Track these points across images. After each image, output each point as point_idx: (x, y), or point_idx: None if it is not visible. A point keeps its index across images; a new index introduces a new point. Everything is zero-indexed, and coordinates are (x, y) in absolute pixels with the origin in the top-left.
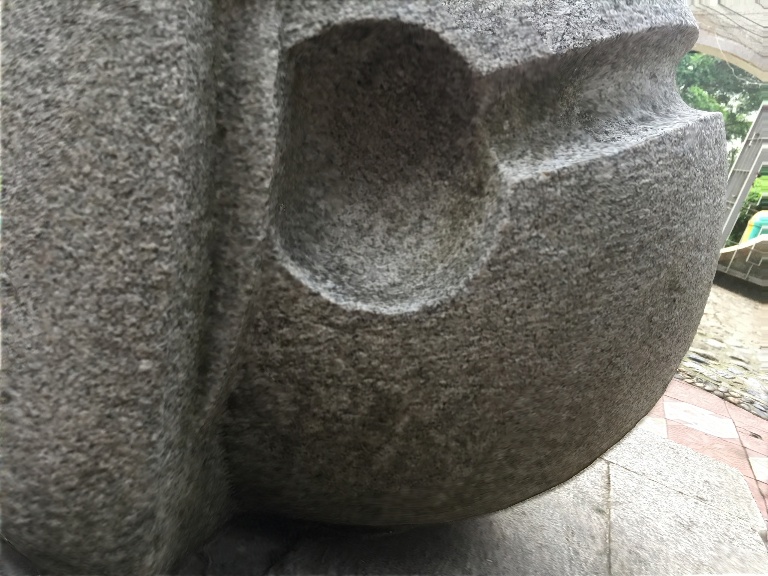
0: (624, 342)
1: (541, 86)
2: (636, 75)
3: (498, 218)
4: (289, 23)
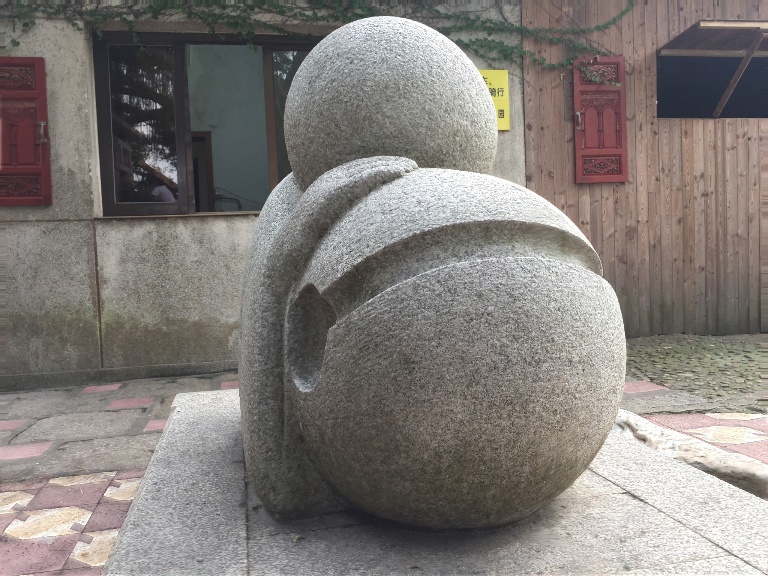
0: (384, 392)
1: (350, 288)
2: (403, 265)
3: None
4: None
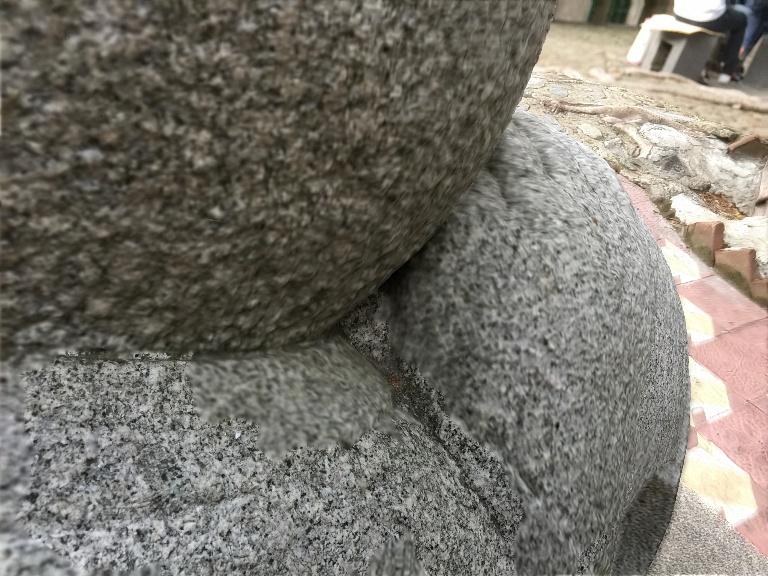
0: None
1: None
2: None
3: (666, 503)
4: None
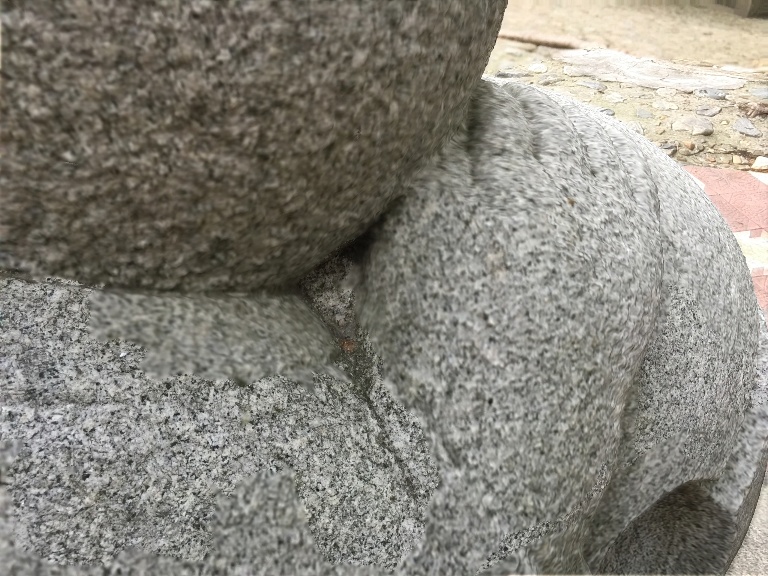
0: None
1: None
2: None
3: (726, 532)
4: (589, 556)
